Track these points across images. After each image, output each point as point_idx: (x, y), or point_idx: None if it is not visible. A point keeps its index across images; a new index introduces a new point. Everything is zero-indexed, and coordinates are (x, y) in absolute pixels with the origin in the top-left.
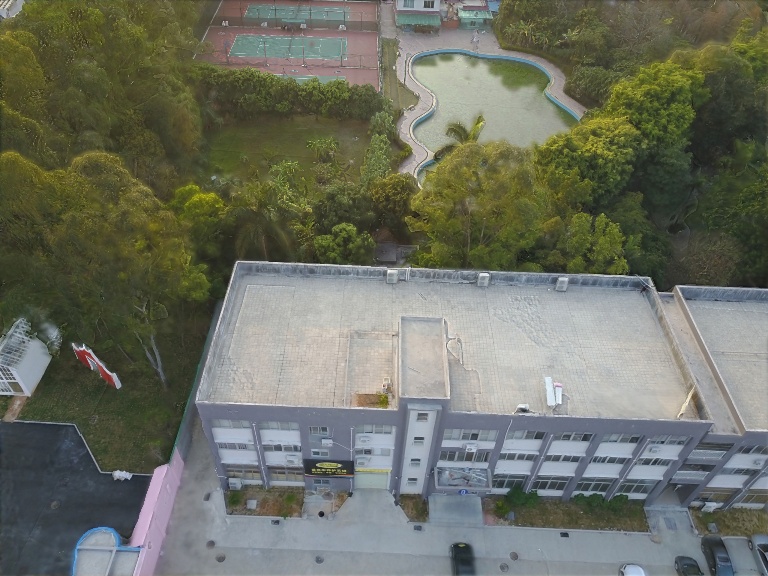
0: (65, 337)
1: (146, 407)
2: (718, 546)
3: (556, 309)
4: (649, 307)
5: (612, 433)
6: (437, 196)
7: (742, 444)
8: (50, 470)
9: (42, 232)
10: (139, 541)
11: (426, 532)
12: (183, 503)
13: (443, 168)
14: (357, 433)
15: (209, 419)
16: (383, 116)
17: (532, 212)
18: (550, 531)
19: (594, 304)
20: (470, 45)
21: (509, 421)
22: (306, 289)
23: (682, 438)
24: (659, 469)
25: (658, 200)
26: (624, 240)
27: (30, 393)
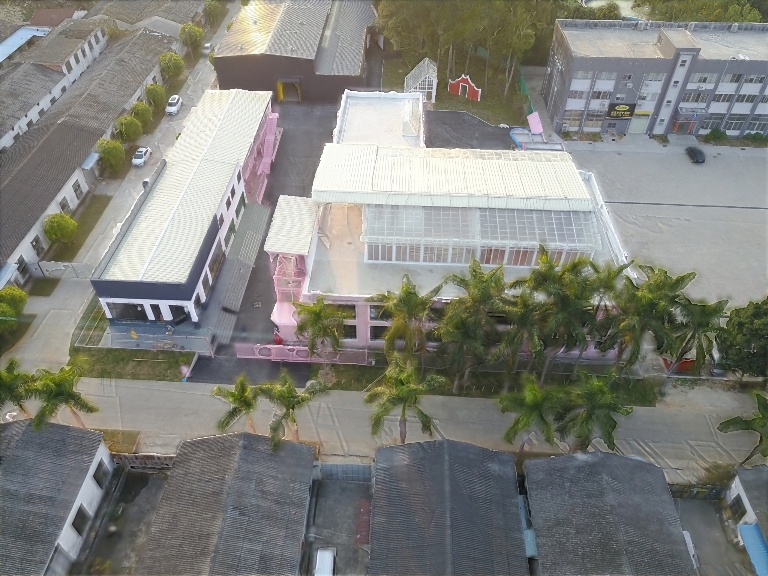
0: None
1: (498, 107)
2: None
3: (733, 38)
4: None
5: None
6: None
7: None
8: (465, 125)
9: None
10: None
11: (671, 145)
12: None
13: None
14: (645, 80)
15: (574, 71)
16: None
17: None
18: (735, 148)
19: (753, 36)
20: None
21: (726, 65)
22: (595, 32)
23: None
24: None
25: None
26: (761, 18)
27: (434, 101)
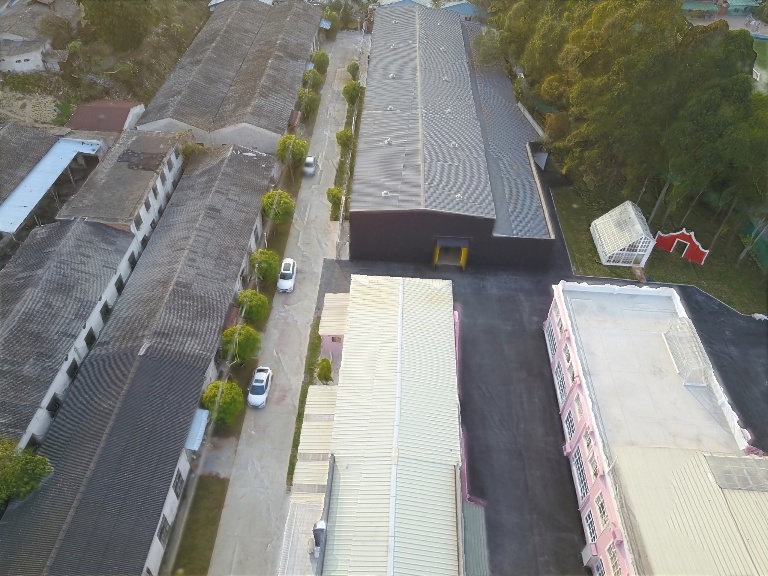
0: None
1: (733, 277)
2: None
3: None
4: None
5: None
6: None
7: None
8: (704, 312)
9: None
10: None
11: None
12: None
13: None
14: None
15: None
16: None
17: None
18: None
19: None
20: (747, 28)
21: None
22: None
23: None
24: None
25: None
26: None
27: None
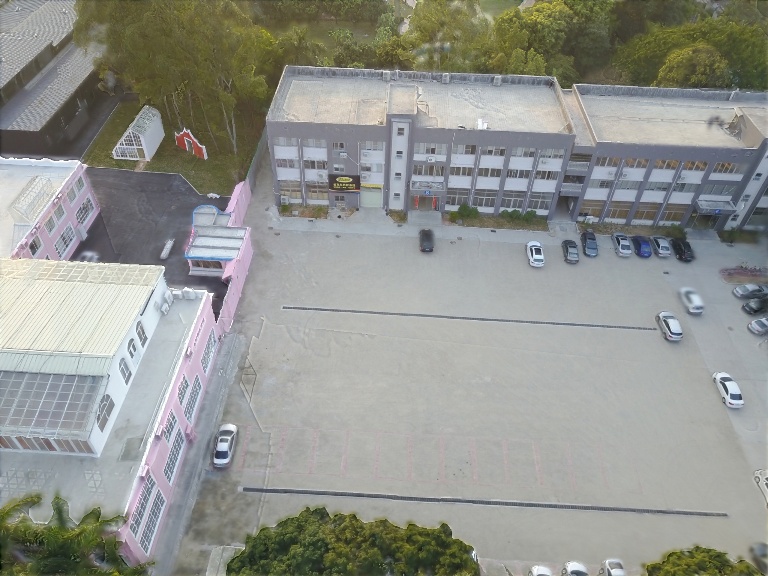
0: (167, 134)
1: (225, 168)
2: (590, 235)
3: (492, 94)
4: (553, 94)
5: (517, 147)
6: (418, 31)
7: (597, 155)
8: (168, 193)
9: (179, 15)
10: (230, 210)
11: (405, 225)
12: (252, 211)
13: (420, 3)
14: (362, 149)
15: (273, 137)
16: (387, 16)
17: (476, 28)
18: (484, 229)
19: (517, 92)
20: None
21: (453, 134)
22: (330, 83)
23: (561, 152)
24: (552, 183)
25: (585, 61)
26: (546, 65)
27: (149, 159)
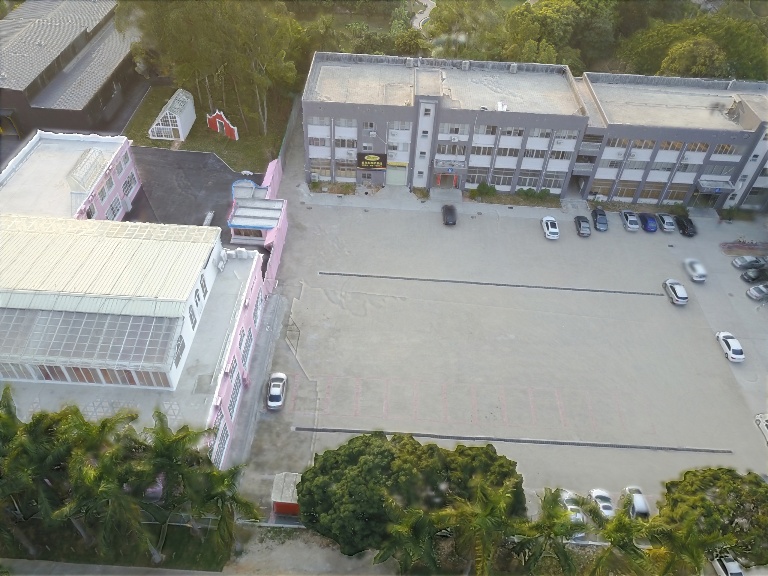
0: (198, 117)
1: (255, 148)
2: (600, 211)
3: (509, 80)
4: (566, 81)
5: (534, 128)
6: (438, 21)
7: (608, 136)
8: (204, 170)
9: (222, 1)
10: None
11: (428, 201)
12: (284, 188)
13: None
14: (390, 129)
15: (307, 116)
16: (400, 10)
17: (494, 18)
18: (502, 206)
19: (532, 79)
20: None
21: (476, 115)
22: (357, 68)
23: (575, 133)
24: (565, 163)
25: (591, 54)
26: (557, 56)
27: (184, 139)
